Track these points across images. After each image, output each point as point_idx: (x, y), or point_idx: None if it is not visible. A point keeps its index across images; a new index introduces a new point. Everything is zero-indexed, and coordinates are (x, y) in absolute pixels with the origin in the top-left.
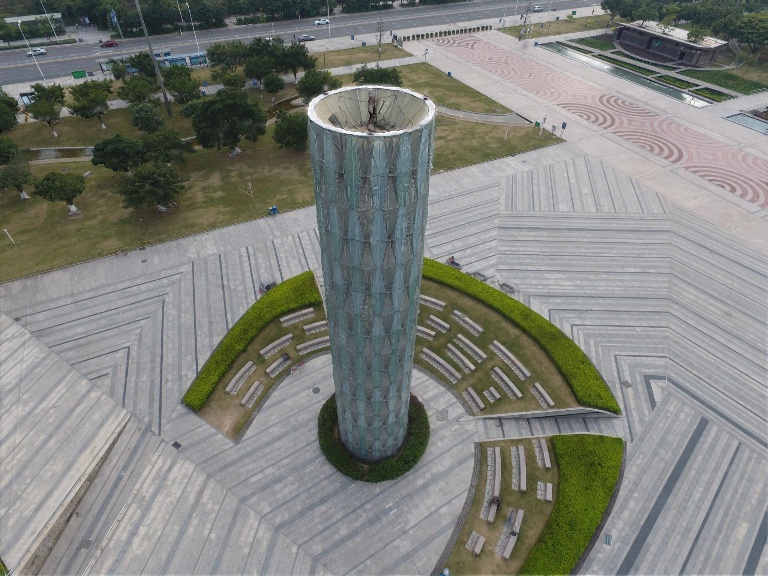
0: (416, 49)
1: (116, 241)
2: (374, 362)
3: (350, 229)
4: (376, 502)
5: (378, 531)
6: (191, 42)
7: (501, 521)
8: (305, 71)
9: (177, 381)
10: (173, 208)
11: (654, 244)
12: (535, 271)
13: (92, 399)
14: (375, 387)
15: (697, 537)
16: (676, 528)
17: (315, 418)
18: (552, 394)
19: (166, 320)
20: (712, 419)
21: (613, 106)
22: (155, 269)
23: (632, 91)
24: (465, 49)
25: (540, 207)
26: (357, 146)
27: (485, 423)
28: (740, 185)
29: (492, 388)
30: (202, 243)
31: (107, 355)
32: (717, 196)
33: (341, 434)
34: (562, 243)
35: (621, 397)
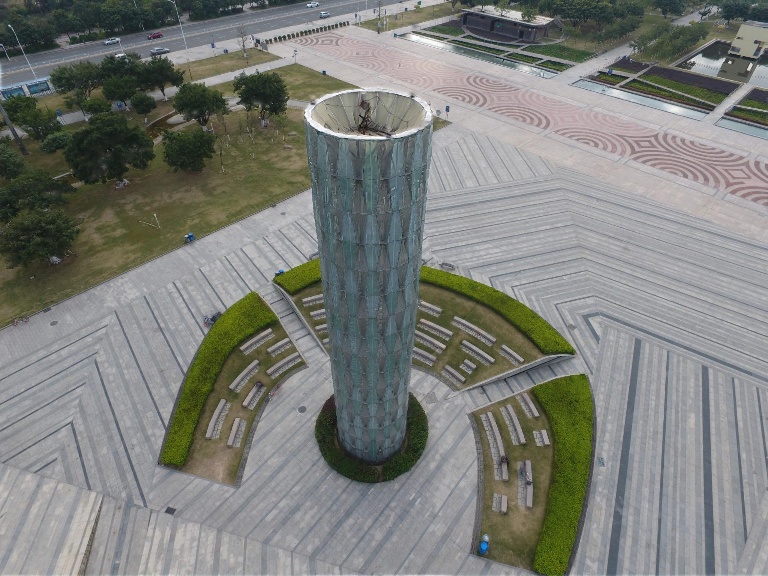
0: (282, 51)
1: (8, 308)
2: (386, 361)
3: (367, 234)
4: (399, 498)
5: (411, 524)
6: (24, 68)
7: (514, 476)
8: (179, 86)
9: (145, 443)
10: (69, 257)
11: (553, 202)
12: (465, 246)
13: (46, 493)
14: (387, 386)
15: (664, 437)
16: (647, 435)
17: (311, 437)
18: (519, 352)
19: (107, 381)
20: (643, 338)
21: (480, 85)
22: (71, 329)
23: (491, 70)
24: (330, 46)
25: (450, 187)
26: (377, 150)
27: (470, 394)
28: (600, 140)
29: (467, 360)
30: (119, 289)
31: (47, 439)
32: (586, 152)
33: (346, 444)
34: (480, 216)
35: (571, 339)
